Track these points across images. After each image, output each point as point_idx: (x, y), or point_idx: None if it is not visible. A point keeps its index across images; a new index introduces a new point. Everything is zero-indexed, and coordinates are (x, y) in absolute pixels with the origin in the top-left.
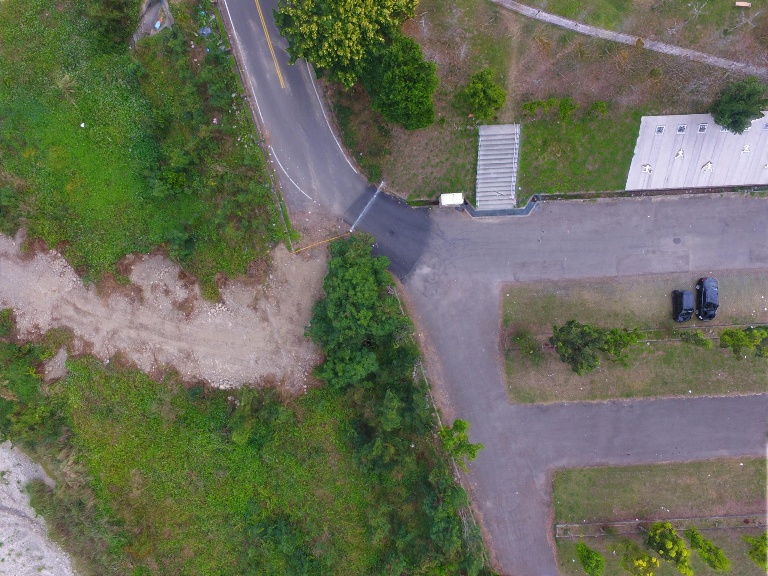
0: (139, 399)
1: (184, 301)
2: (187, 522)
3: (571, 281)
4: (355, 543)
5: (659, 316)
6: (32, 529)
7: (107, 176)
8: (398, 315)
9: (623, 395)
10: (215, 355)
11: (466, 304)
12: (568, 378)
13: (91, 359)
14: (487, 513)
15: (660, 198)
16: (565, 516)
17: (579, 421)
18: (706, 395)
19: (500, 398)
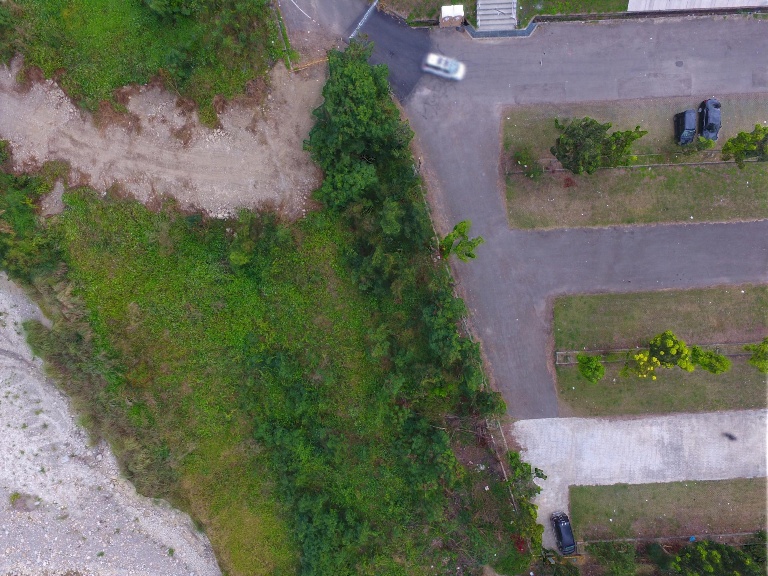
0: (137, 230)
1: (182, 128)
2: (185, 357)
3: (572, 104)
4: (354, 369)
5: (661, 141)
6: (29, 373)
7: (104, 2)
8: (398, 121)
9: (624, 221)
10: (213, 181)
11: (466, 127)
12: (569, 203)
13: (88, 189)
14: (487, 340)
15: (662, 20)
16: (565, 343)
17: (580, 247)
18: (708, 221)
19: (500, 223)
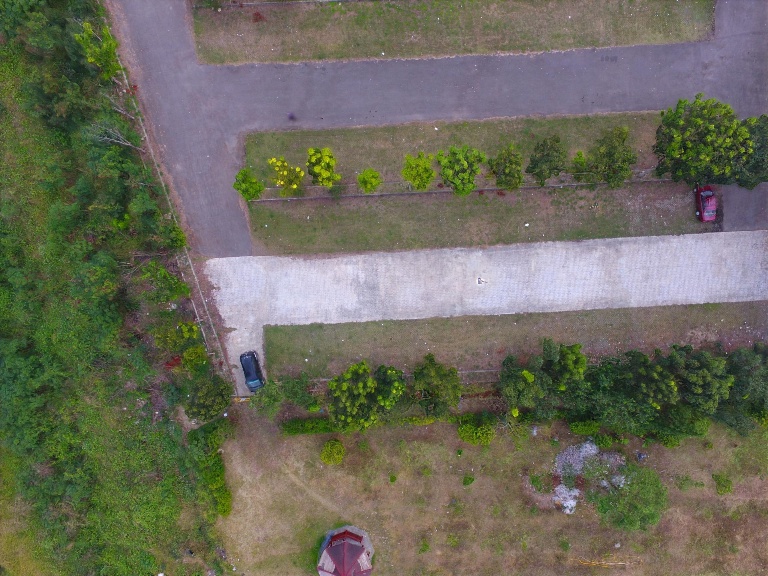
0: None
1: None
2: None
3: None
4: (40, 205)
5: None
6: None
7: None
8: None
9: (315, 57)
10: None
11: None
12: (259, 38)
13: None
14: (177, 176)
15: None
16: (258, 181)
17: (270, 83)
18: (399, 58)
19: (189, 58)
